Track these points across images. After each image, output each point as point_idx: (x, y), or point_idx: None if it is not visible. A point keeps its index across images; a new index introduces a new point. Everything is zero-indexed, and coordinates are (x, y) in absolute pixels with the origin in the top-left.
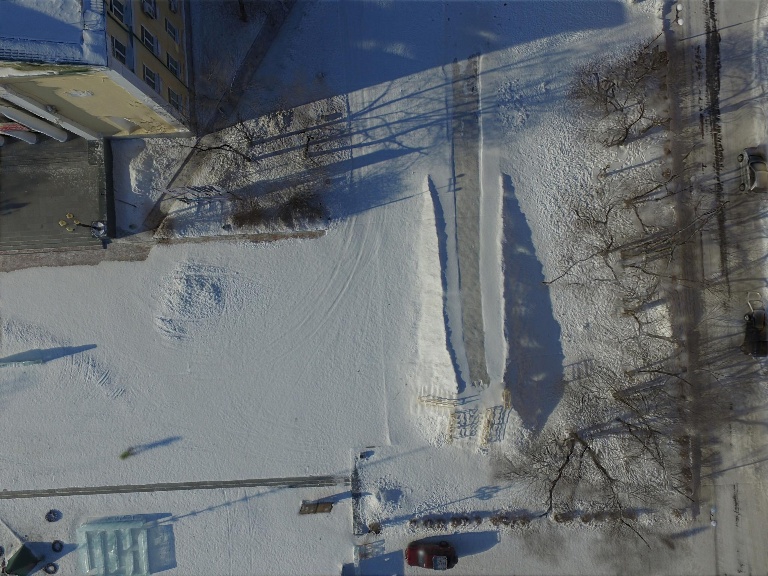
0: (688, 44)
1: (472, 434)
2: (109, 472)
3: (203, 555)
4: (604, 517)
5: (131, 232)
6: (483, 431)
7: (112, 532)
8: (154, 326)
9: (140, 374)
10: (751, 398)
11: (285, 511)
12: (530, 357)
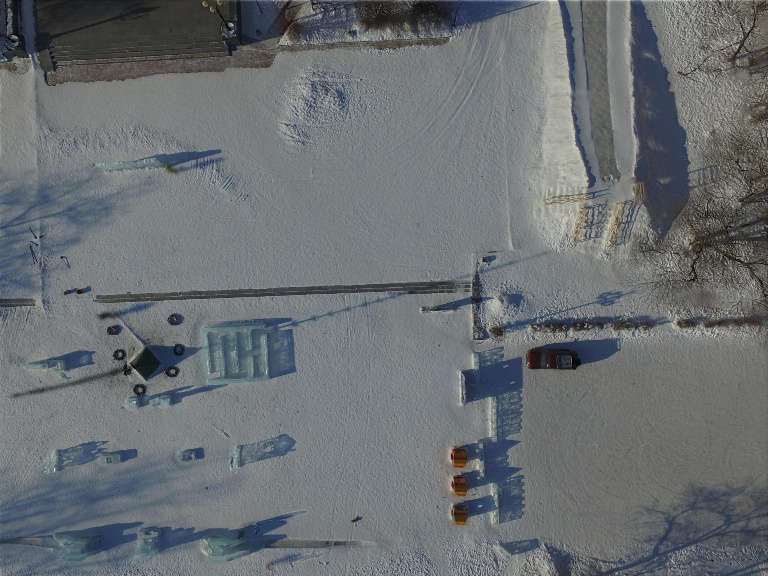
0: None
1: (597, 236)
2: (231, 276)
3: (322, 360)
4: (728, 323)
5: (256, 39)
6: (609, 231)
7: (234, 334)
8: (278, 132)
9: (263, 179)
10: None
11: (404, 317)
12: (656, 160)
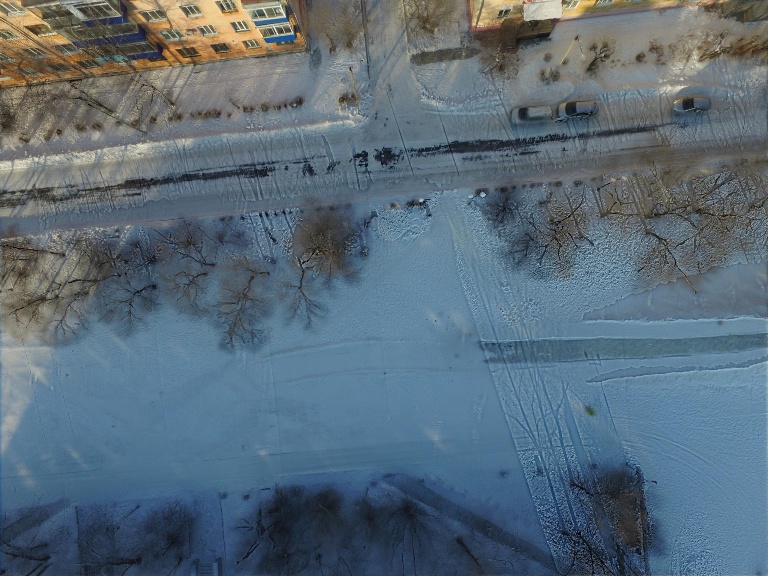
0: (461, 168)
1: None
2: None
3: None
4: None
5: None
6: None
7: None
8: None
9: None
10: (763, 101)
11: None
12: (744, 293)
